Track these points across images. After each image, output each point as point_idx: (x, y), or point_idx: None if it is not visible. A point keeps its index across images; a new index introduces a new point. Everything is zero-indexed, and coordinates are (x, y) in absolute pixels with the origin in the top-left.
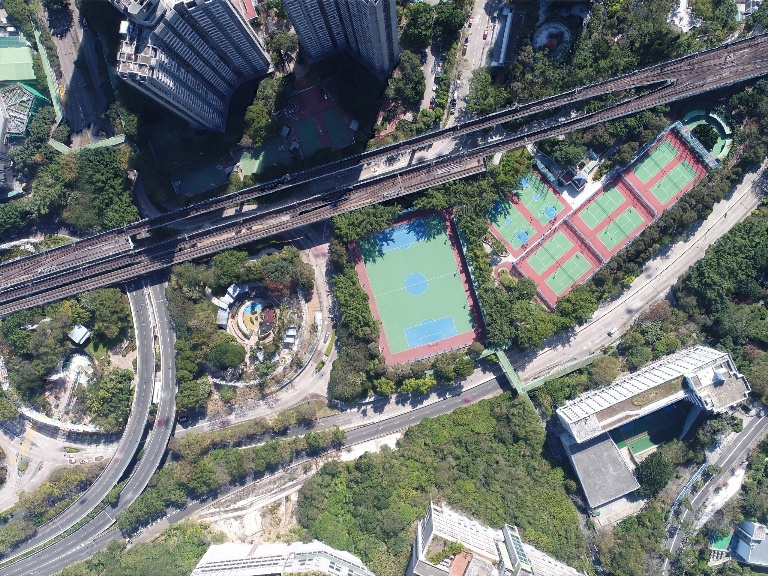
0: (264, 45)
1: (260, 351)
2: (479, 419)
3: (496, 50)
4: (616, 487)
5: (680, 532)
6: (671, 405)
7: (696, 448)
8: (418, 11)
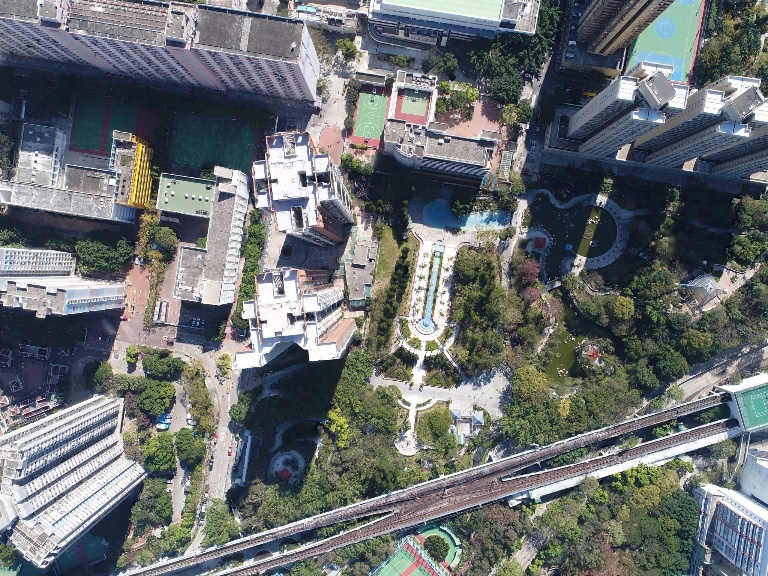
0: None
1: None
2: None
3: (241, 466)
4: None
5: None
6: None
7: None
8: None
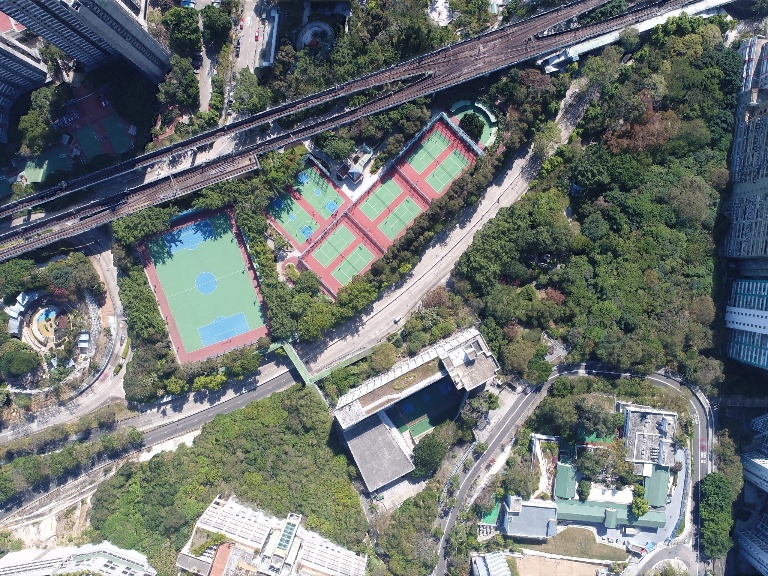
0: (40, 55)
1: (54, 357)
2: (269, 412)
3: (268, 51)
4: (392, 470)
5: (454, 510)
6: (447, 387)
7: (463, 427)
8: (179, 16)
